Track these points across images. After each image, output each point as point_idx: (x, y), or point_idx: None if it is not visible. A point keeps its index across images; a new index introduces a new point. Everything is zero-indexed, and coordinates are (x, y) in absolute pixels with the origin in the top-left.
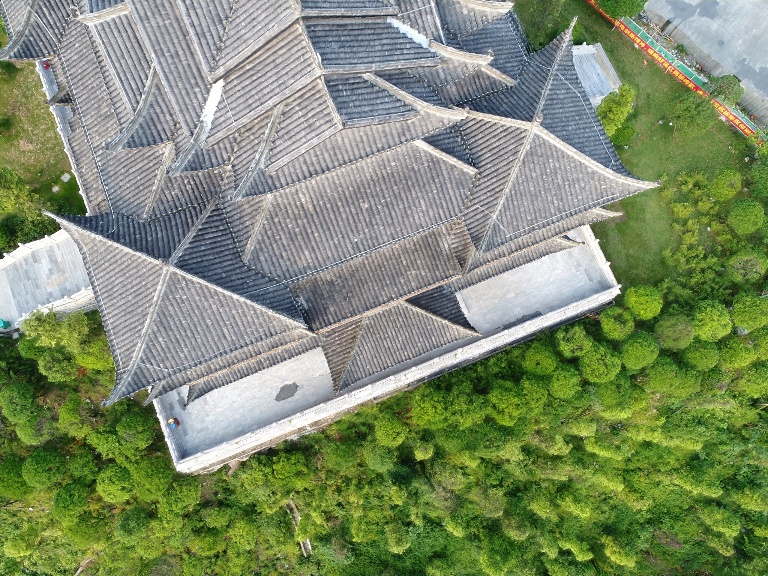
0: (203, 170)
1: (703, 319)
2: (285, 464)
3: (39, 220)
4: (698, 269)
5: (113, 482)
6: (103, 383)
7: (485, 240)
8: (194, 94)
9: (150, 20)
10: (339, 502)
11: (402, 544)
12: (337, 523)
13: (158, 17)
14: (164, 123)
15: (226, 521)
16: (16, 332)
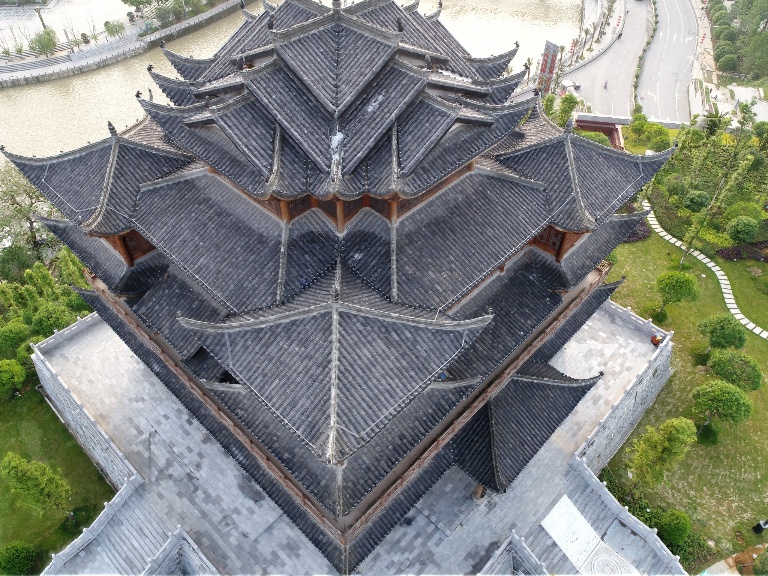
0: None
1: None
2: None
3: None
4: None
5: None
6: None
7: None
8: None
9: None
10: None
11: None
12: None
13: None
14: None
15: None
16: None
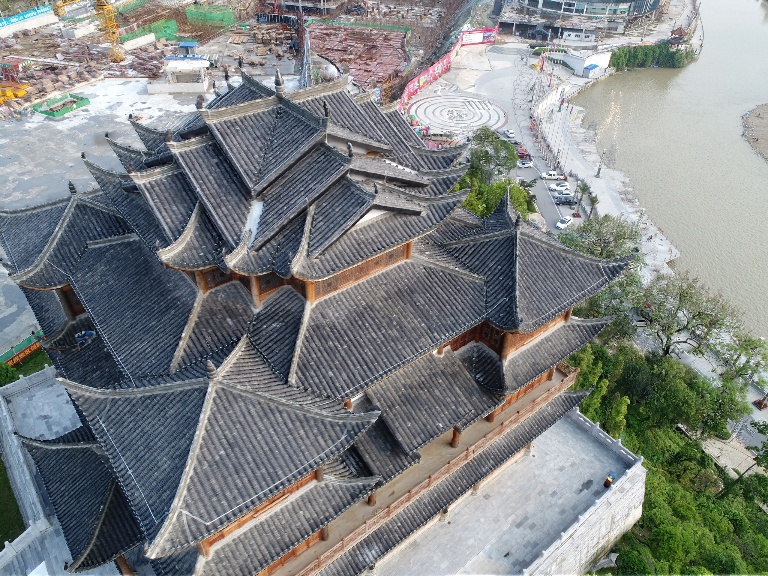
0: None
1: None
2: None
3: None
4: None
5: None
6: None
7: None
8: None
9: None
10: None
11: None
12: None
13: None
14: None
15: None
16: None
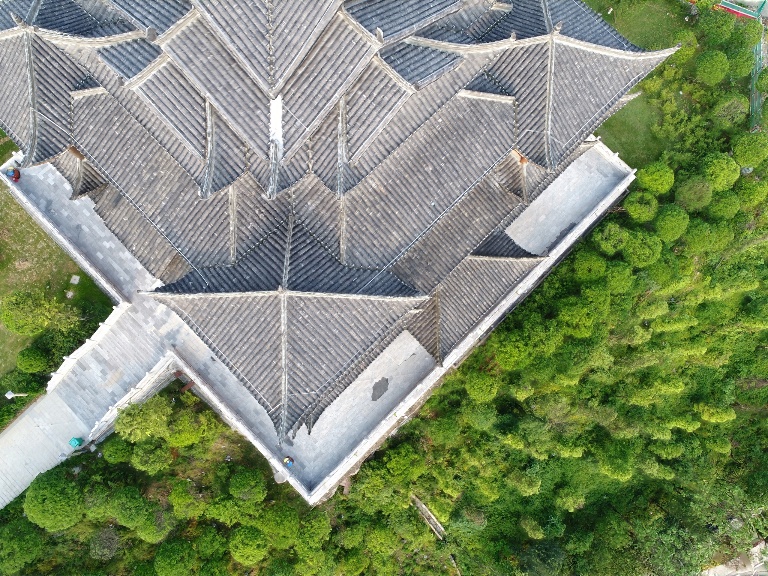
0: (291, 186)
1: (714, 172)
2: (398, 459)
3: (68, 330)
4: (688, 131)
5: (247, 544)
6: (198, 456)
7: (551, 156)
8: (257, 117)
9: (193, 62)
10: (455, 475)
11: (535, 484)
12: (459, 496)
13: (200, 56)
14: (234, 157)
15: (361, 537)
16: (92, 444)
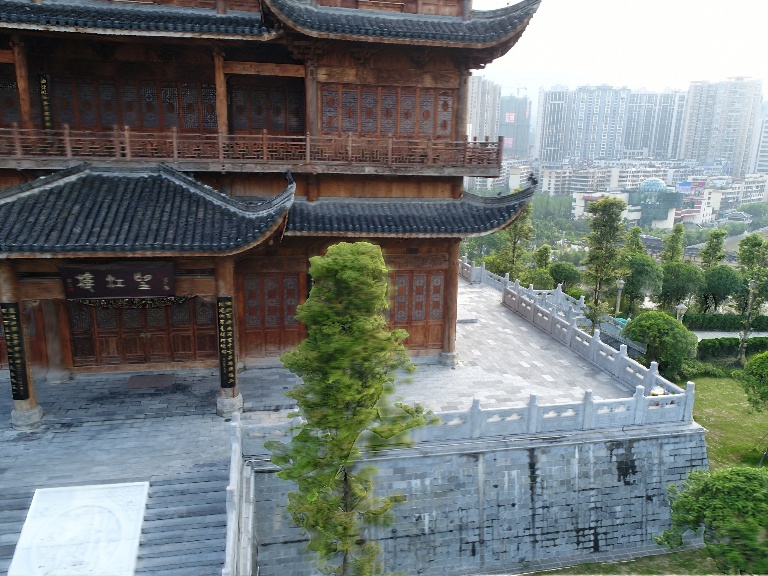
0: None
1: None
2: None
3: None
4: None
5: None
6: None
7: None
8: None
9: None
10: None
11: None
12: None
13: None
14: None
15: None
16: None
